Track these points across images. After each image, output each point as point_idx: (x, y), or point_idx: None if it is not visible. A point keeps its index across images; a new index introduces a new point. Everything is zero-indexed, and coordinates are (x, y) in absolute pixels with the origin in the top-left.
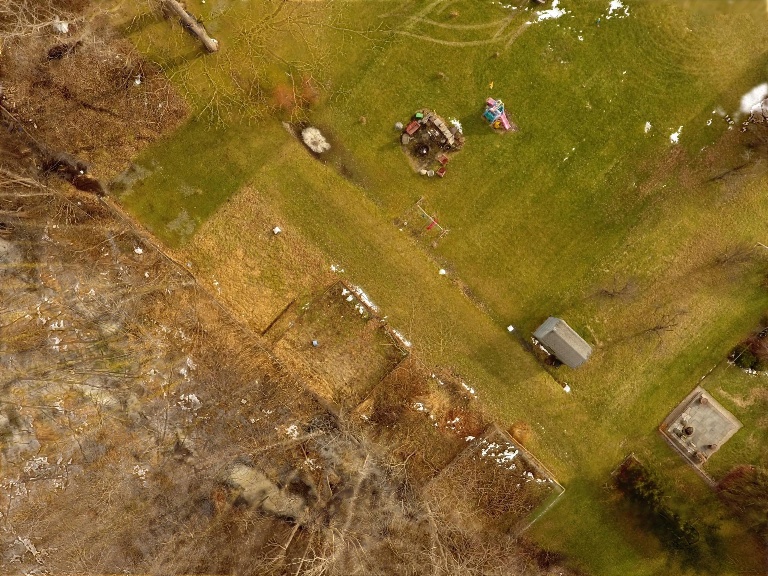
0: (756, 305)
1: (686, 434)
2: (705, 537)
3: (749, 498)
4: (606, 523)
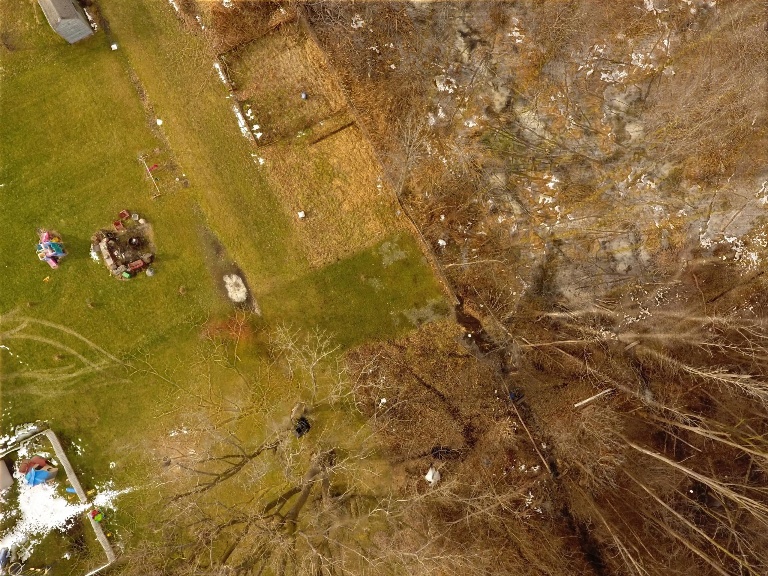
0: None
1: None
2: None
3: None
4: None
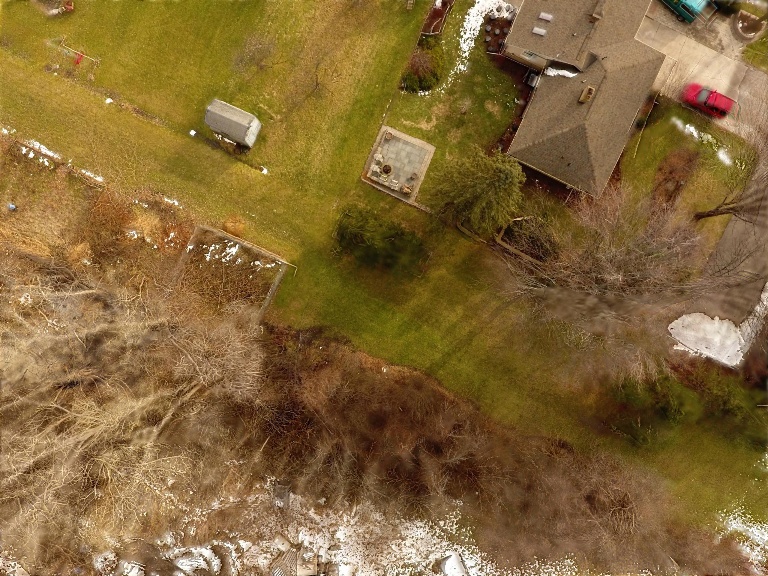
0: (403, 28)
1: (385, 174)
2: (445, 268)
3: (451, 207)
4: (346, 286)
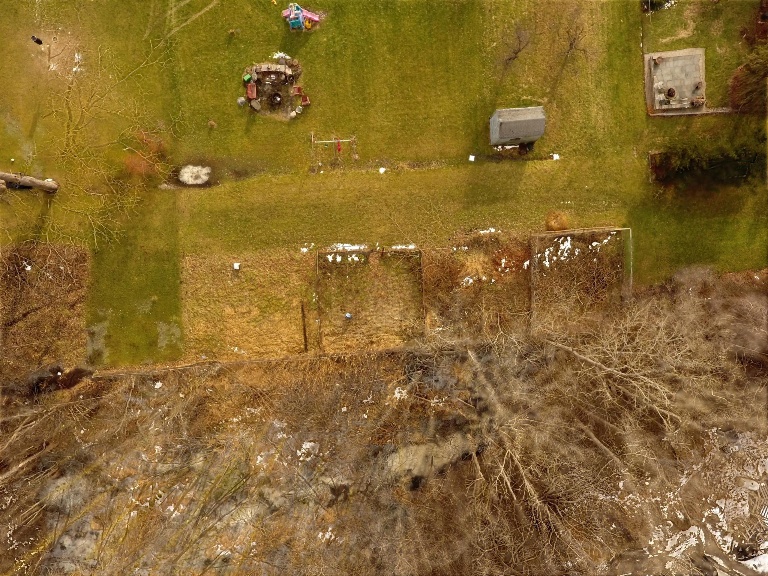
0: None
1: (672, 97)
2: (762, 156)
3: (762, 92)
4: (683, 221)
